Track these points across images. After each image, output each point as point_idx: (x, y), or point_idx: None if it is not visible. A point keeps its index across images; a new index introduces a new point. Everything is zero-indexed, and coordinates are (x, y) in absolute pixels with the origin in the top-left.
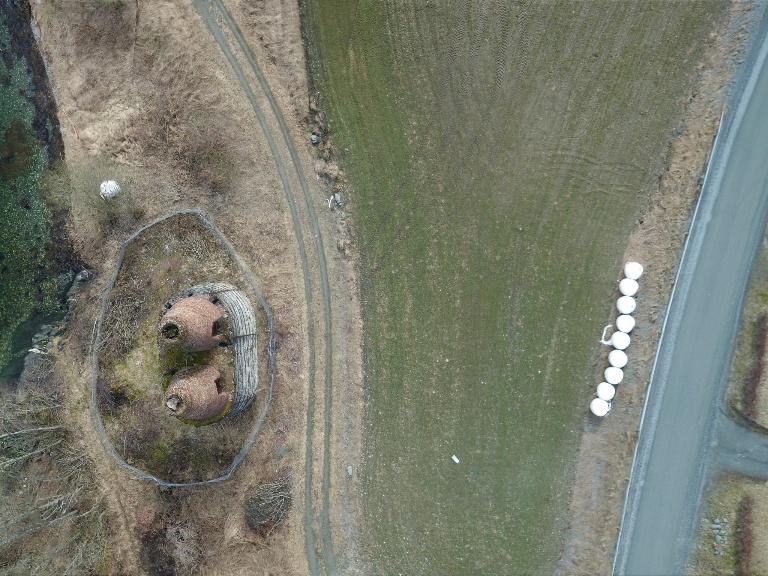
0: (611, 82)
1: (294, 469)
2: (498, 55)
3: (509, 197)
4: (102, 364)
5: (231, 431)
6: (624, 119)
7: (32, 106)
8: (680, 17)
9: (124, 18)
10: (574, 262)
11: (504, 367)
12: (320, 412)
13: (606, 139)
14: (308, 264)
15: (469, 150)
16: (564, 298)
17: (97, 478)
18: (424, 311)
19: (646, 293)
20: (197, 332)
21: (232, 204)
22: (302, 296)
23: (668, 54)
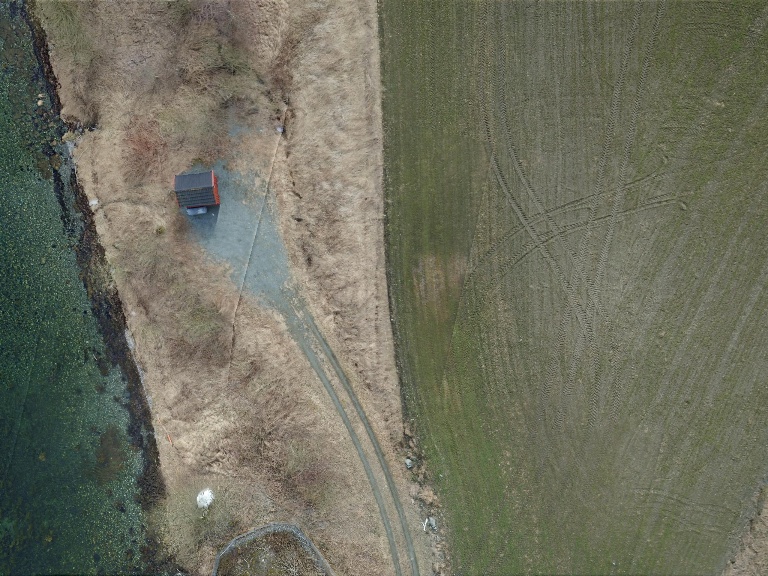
0: (703, 428)
1: None
2: (591, 396)
3: (603, 532)
4: None
5: None
6: (716, 463)
7: (127, 413)
8: None
9: (220, 339)
10: None
11: None
12: None
13: (698, 481)
14: None
15: (563, 484)
16: None
17: None
18: None
19: None
20: None
21: (327, 521)
22: None
23: (759, 404)
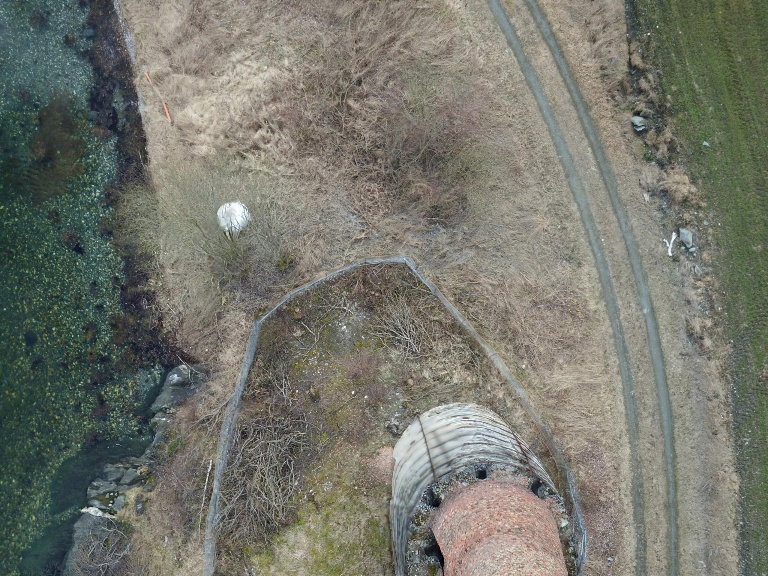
0: None
1: None
2: None
3: None
4: (222, 546)
5: None
6: None
7: (87, 67)
8: None
9: None
10: None
11: None
12: None
13: None
14: (630, 366)
15: None
16: None
17: None
18: None
19: None
20: None
21: (471, 247)
22: (619, 428)
23: None
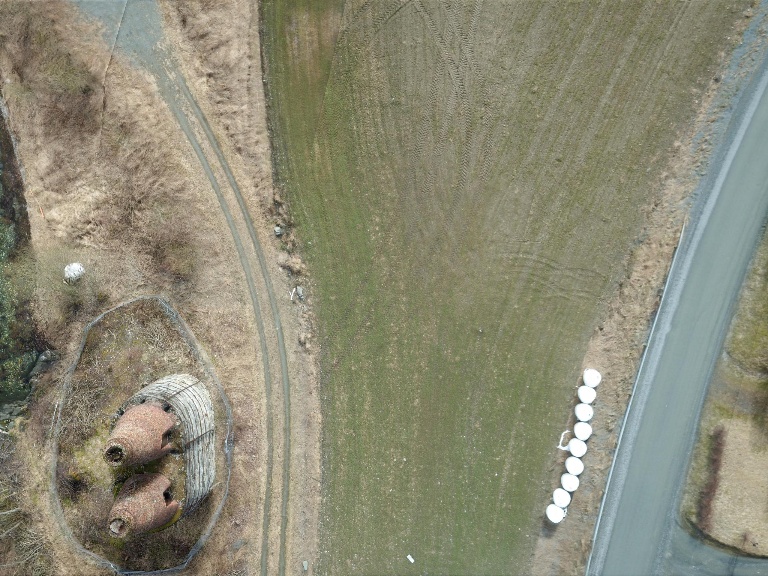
0: (574, 188)
1: (250, 563)
2: (462, 156)
3: (470, 298)
4: (62, 448)
5: (188, 522)
6: (586, 225)
7: None
8: (644, 125)
9: (91, 102)
10: (533, 366)
11: (461, 468)
12: (277, 506)
13: (568, 244)
14: (268, 357)
15: (431, 249)
16: (522, 402)
17: (55, 561)
18: (383, 409)
19: (604, 400)
20: (144, 450)
21: (195, 292)
22: (262, 389)
23: (631, 162)
